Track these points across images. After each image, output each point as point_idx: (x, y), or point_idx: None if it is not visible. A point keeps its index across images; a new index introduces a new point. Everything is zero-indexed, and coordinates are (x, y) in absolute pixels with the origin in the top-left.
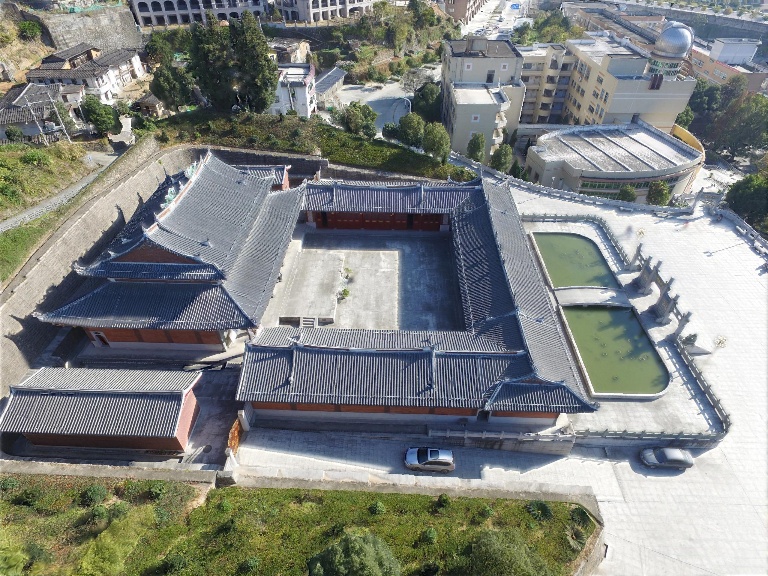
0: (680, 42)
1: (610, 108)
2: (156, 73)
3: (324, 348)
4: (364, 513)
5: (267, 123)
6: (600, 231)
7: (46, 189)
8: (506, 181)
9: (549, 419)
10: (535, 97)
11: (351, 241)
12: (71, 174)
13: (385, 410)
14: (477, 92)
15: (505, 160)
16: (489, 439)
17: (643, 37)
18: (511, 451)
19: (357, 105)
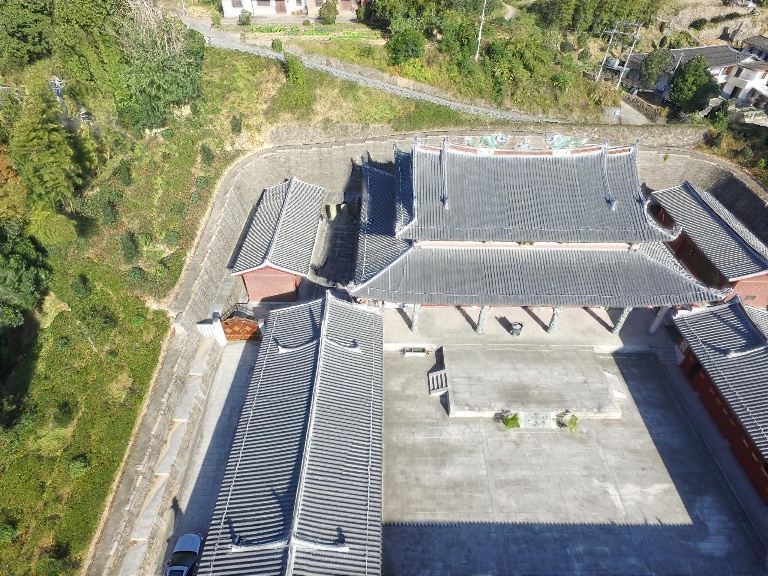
0: None
1: None
2: None
3: None
4: (78, 448)
5: None
6: None
7: (531, 106)
8: None
9: None
10: None
11: (676, 426)
12: (573, 112)
13: None
14: None
15: None
16: None
17: None
18: None
19: None
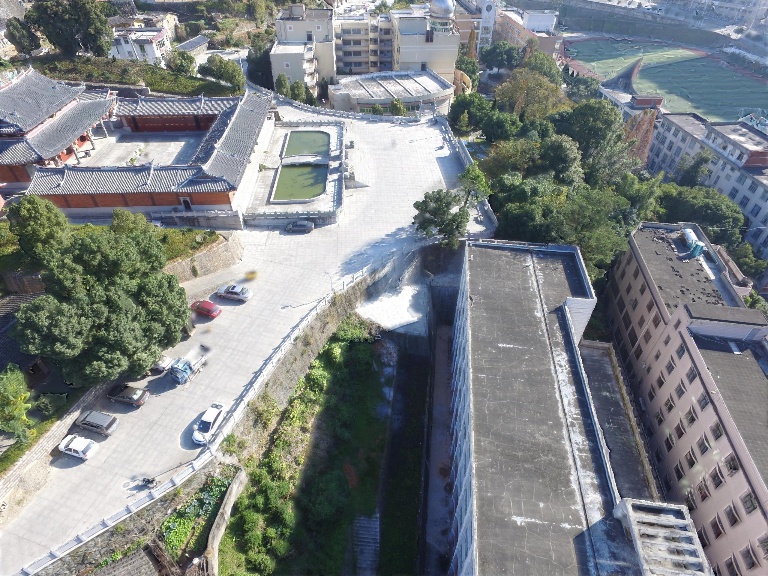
0: (444, 5)
1: (401, 58)
2: (7, 23)
3: (85, 168)
4: None
5: (103, 63)
6: (341, 130)
7: None
8: (270, 96)
9: (226, 205)
10: (368, 57)
11: (154, 138)
12: None
13: (126, 204)
14: (295, 47)
15: (298, 92)
16: (189, 217)
17: (466, 10)
18: (207, 227)
19: (174, 49)
